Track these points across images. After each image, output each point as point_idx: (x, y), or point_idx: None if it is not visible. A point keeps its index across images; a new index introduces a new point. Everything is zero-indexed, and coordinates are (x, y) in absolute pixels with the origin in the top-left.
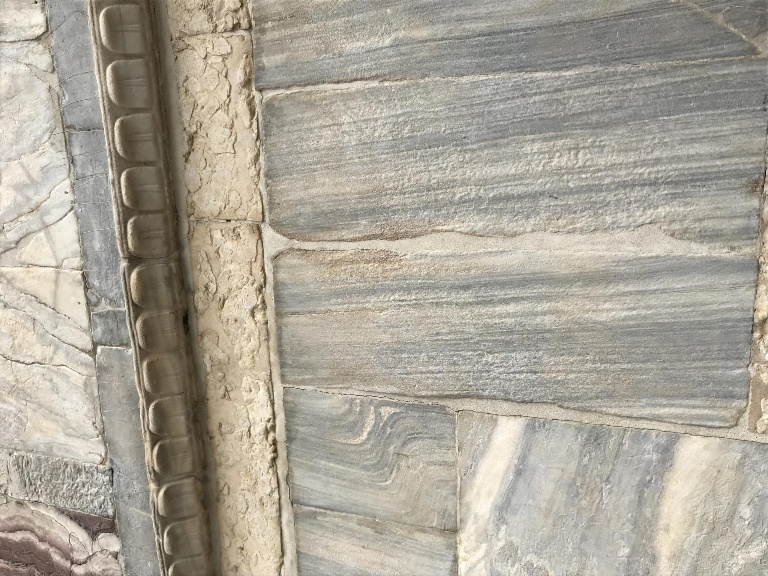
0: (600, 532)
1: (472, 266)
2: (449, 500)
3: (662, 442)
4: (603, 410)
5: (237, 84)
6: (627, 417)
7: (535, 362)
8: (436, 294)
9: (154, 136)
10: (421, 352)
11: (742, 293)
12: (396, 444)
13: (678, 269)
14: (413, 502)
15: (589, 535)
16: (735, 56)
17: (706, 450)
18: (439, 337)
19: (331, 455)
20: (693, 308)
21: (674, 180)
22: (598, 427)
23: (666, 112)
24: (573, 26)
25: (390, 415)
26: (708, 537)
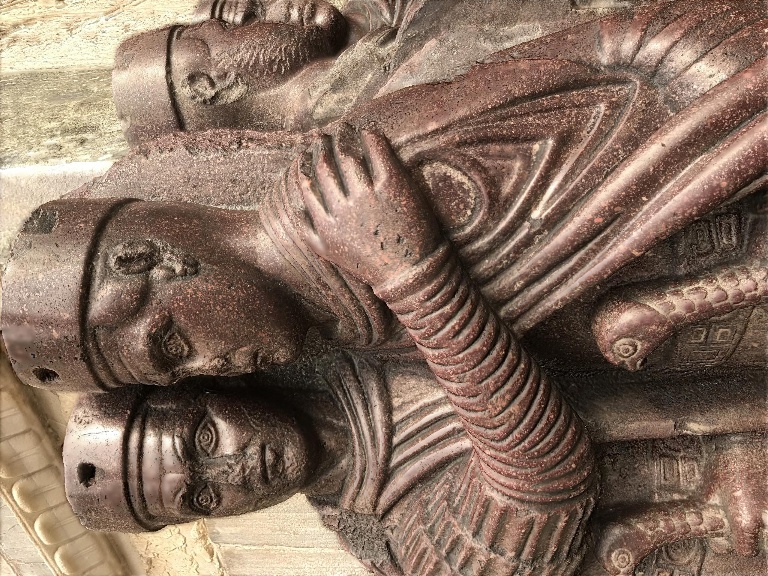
0: None
1: None
2: None
3: None
4: None
5: (192, 538)
6: None
7: None
8: None
9: (114, 574)
10: None
11: None
12: None
13: None
14: None
15: None
16: None
17: None
18: None
19: None
20: None
21: None
22: None
23: None
24: None
25: None
26: None
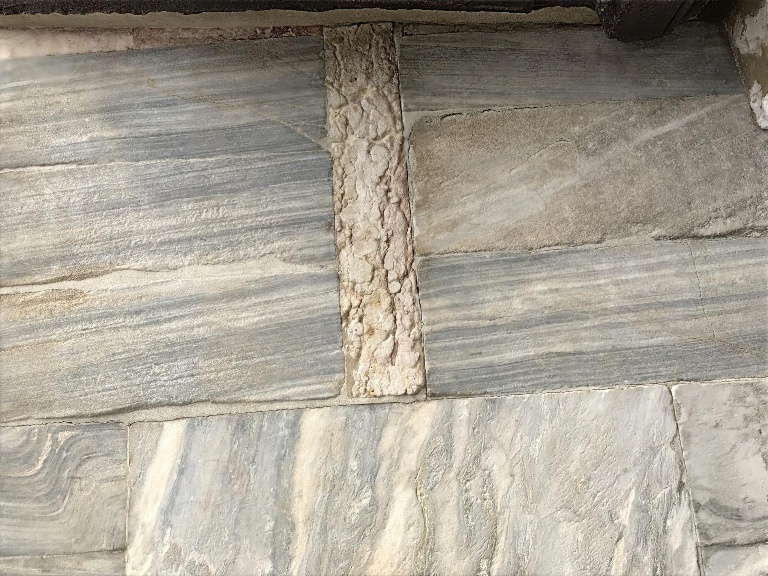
0: (250, 513)
1: (143, 295)
2: (119, 515)
3: (291, 418)
4: (246, 399)
5: None
6: (264, 401)
7: (193, 367)
8: (113, 321)
9: None
10: (98, 373)
11: (331, 296)
12: (71, 468)
13: (290, 283)
14: (84, 528)
15: (241, 518)
16: (309, 150)
17: (322, 419)
18: (115, 357)
19: (3, 493)
20: (302, 310)
21: (281, 224)
22: (243, 415)
23: (273, 182)
24: (213, 132)
25: (67, 439)
26: (331, 495)
